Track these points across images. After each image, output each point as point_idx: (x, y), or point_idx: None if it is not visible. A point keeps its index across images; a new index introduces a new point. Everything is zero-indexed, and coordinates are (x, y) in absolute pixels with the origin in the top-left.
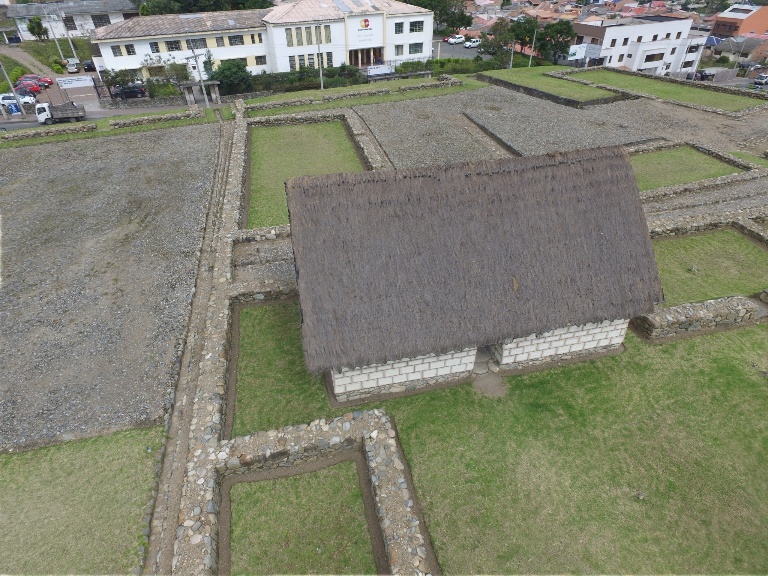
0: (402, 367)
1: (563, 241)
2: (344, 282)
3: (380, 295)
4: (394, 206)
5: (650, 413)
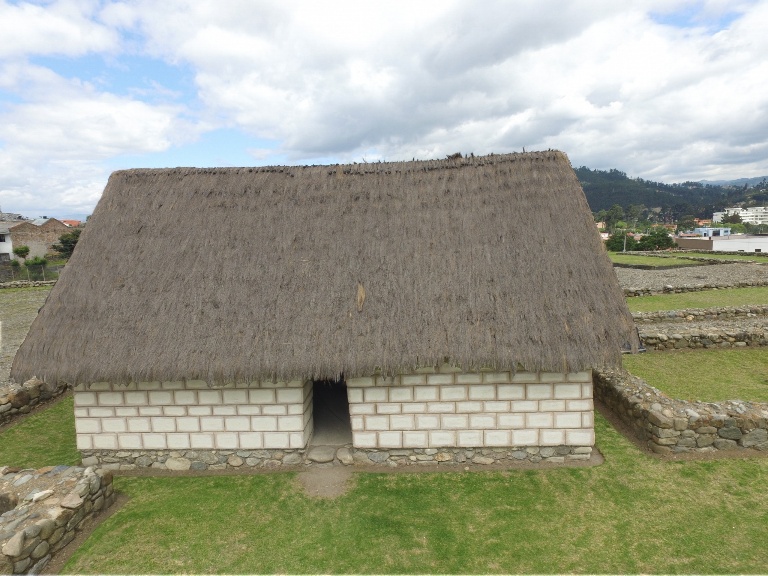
0: (179, 416)
1: (453, 248)
2: (118, 268)
3: (157, 288)
4: (225, 197)
5: (620, 574)
